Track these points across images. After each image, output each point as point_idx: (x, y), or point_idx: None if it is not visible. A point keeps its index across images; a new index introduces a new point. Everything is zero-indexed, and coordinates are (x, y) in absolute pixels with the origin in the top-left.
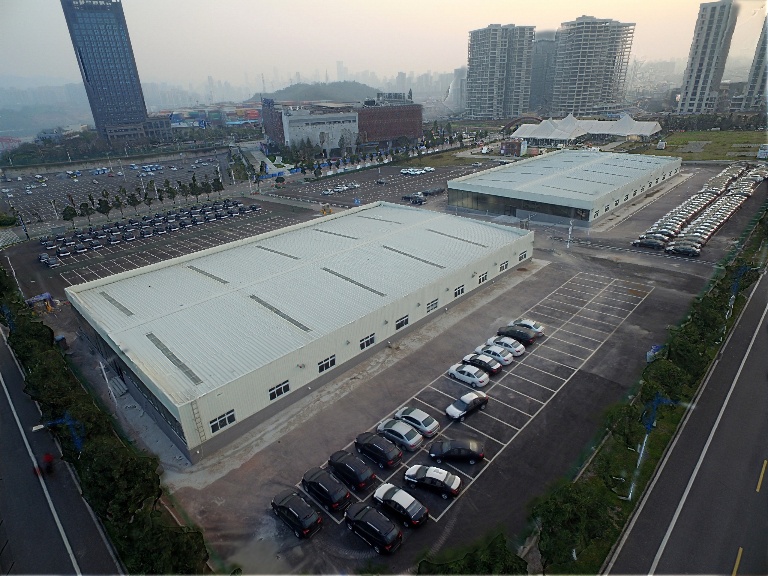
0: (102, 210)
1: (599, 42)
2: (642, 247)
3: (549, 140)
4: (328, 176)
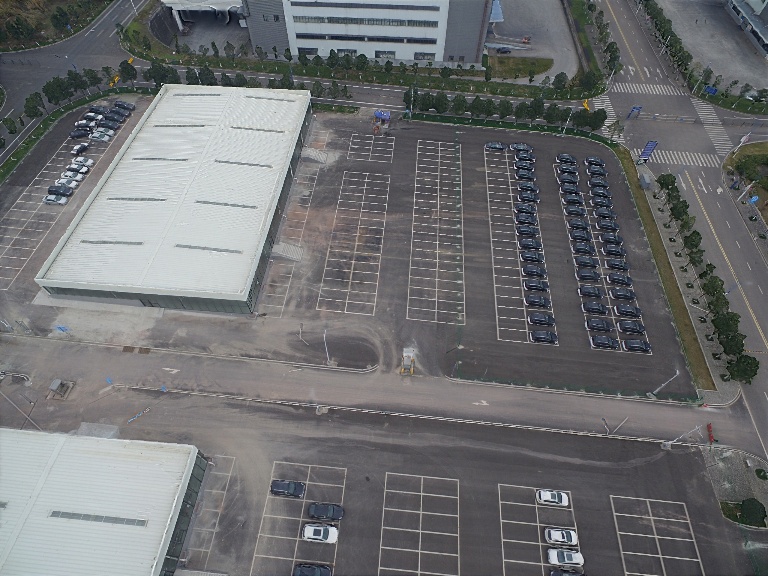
0: None
1: None
2: None
3: None
4: None
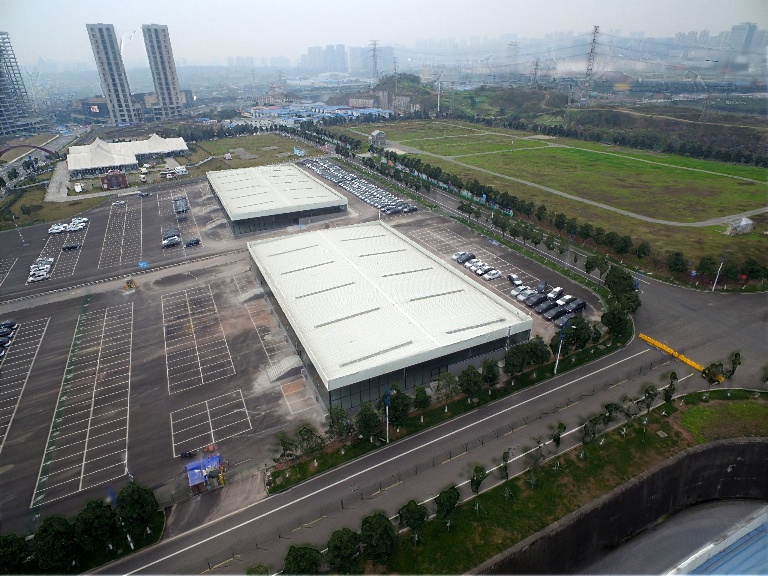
0: None
1: None
2: (393, 214)
3: (118, 167)
4: None
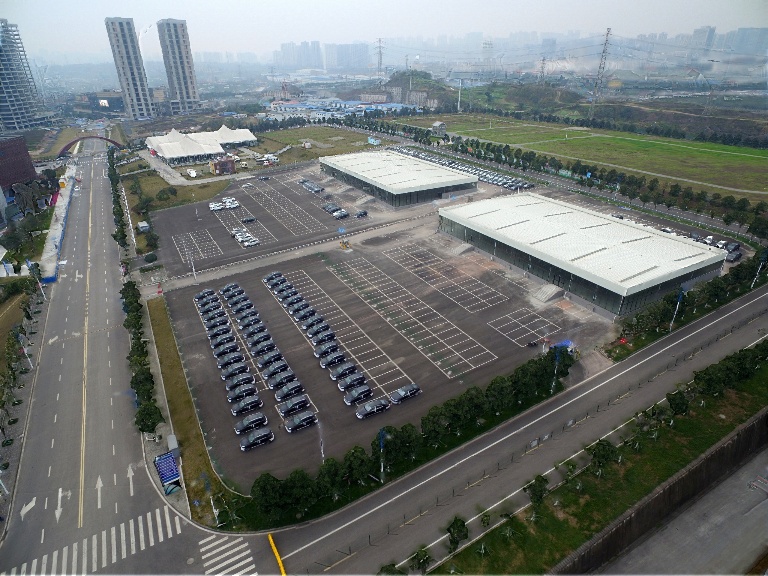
0: None
1: (4, 44)
2: None
3: (208, 155)
4: None
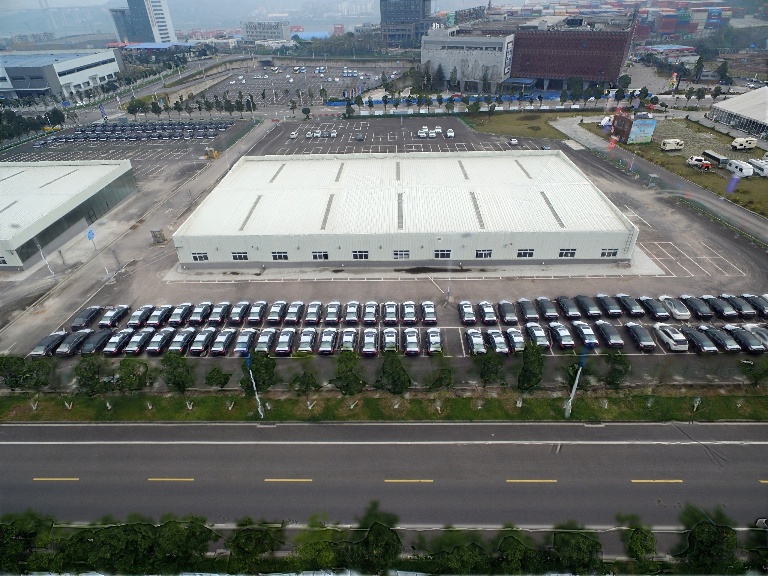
0: (154, 110)
1: None
2: None
3: (762, 126)
4: (363, 116)
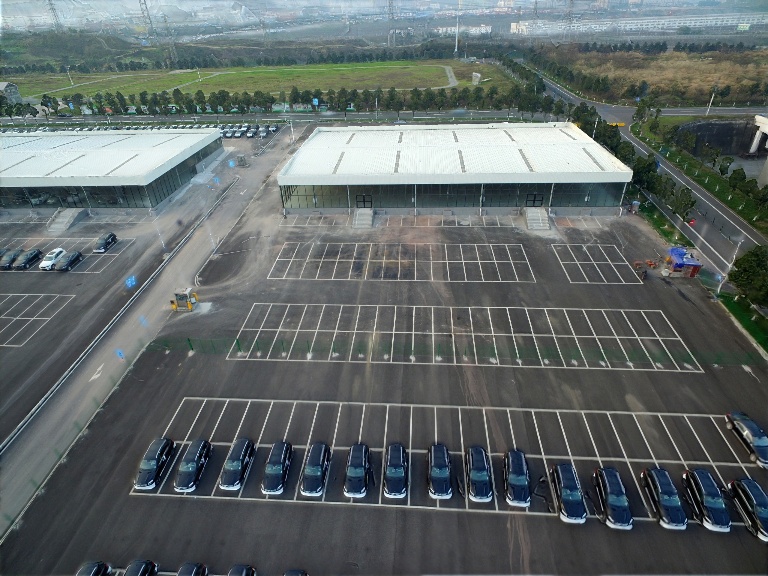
0: None
1: None
2: None
3: None
4: None
